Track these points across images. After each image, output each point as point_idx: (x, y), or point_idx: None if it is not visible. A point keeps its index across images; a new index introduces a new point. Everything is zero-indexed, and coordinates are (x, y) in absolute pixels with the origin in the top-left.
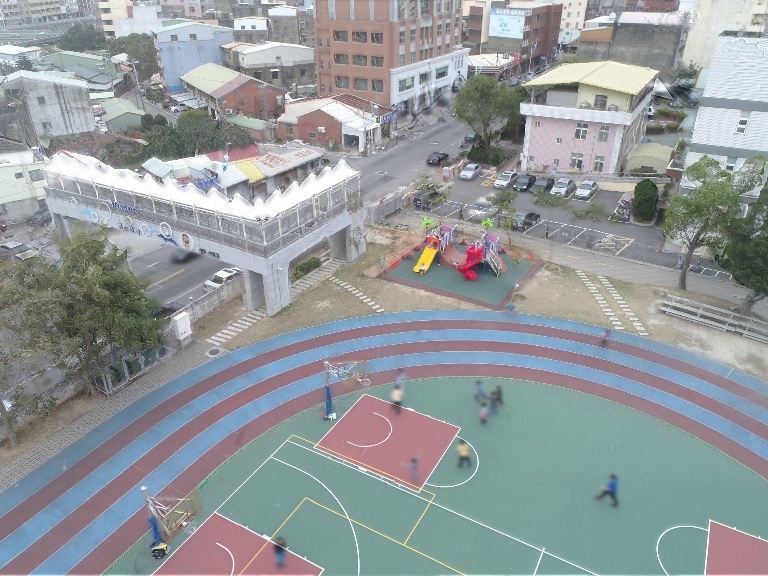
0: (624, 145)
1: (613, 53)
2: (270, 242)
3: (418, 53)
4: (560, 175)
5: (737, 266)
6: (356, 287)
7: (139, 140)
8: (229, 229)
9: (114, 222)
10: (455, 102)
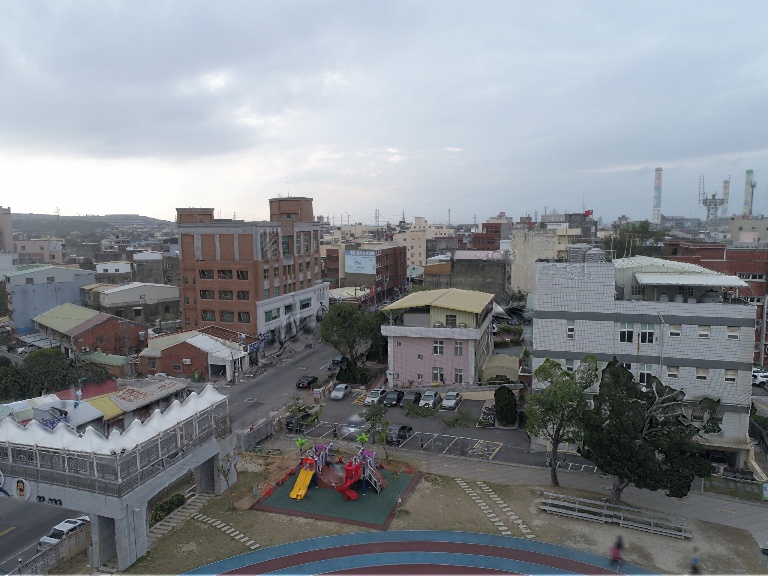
0: (478, 357)
1: (454, 283)
2: (126, 479)
3: (282, 287)
4: (425, 389)
5: (598, 455)
6: (226, 523)
7: None
8: (77, 469)
9: None
10: None
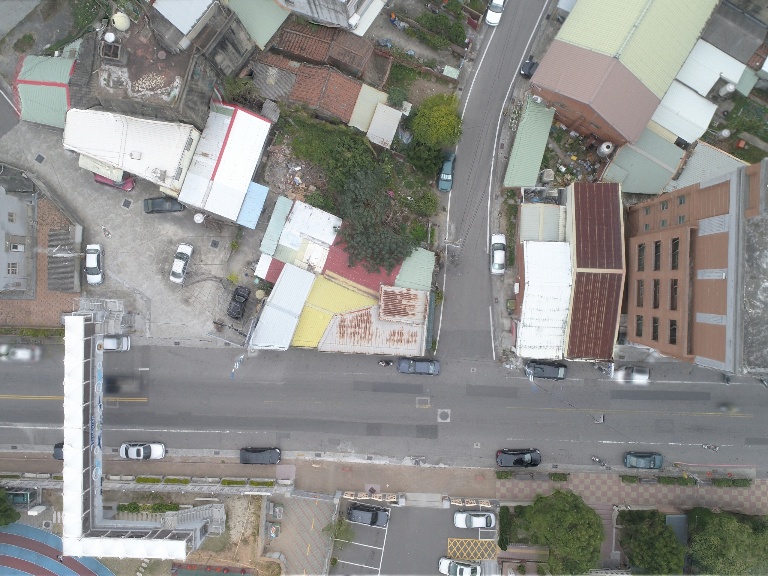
0: None
1: None
2: None
3: None
4: None
5: None
6: None
7: (368, 91)
8: None
9: None
10: (554, 495)
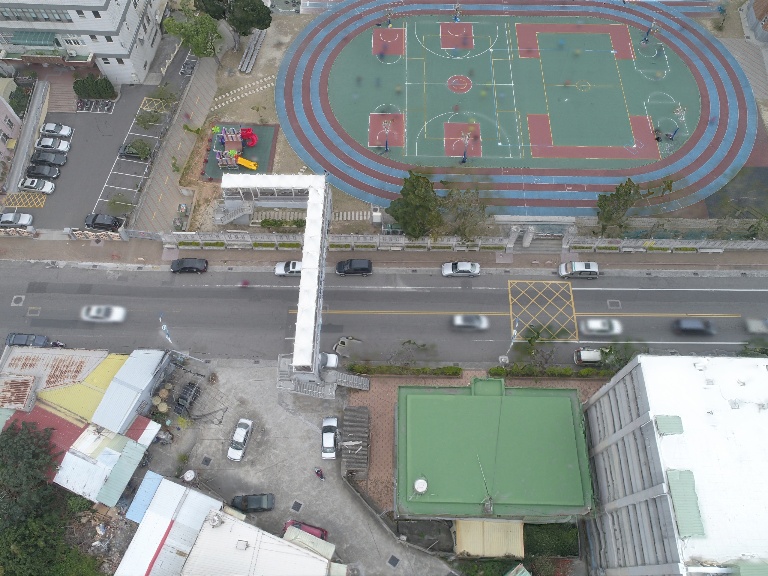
0: None
1: None
2: None
3: None
4: None
5: (261, 26)
6: None
7: None
8: None
9: None
10: None
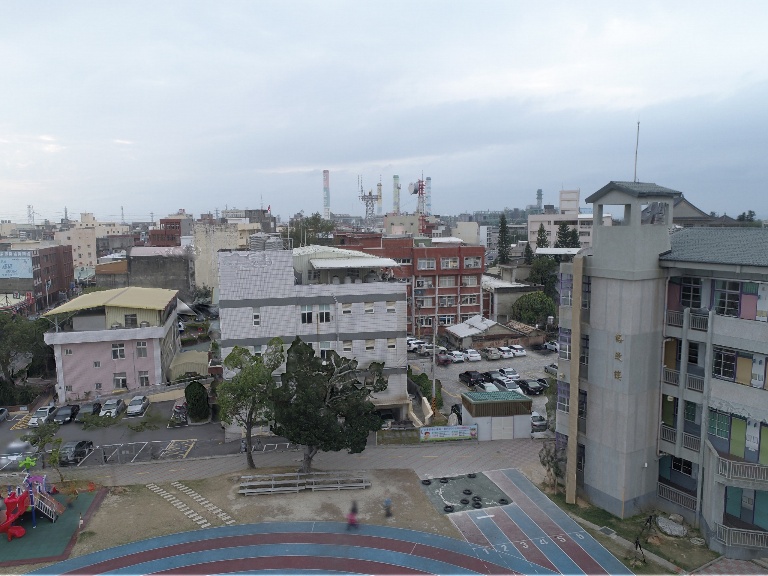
0: (164, 357)
1: (133, 282)
2: None
3: None
4: (106, 398)
5: (288, 429)
6: None
7: None
8: None
9: None
10: None
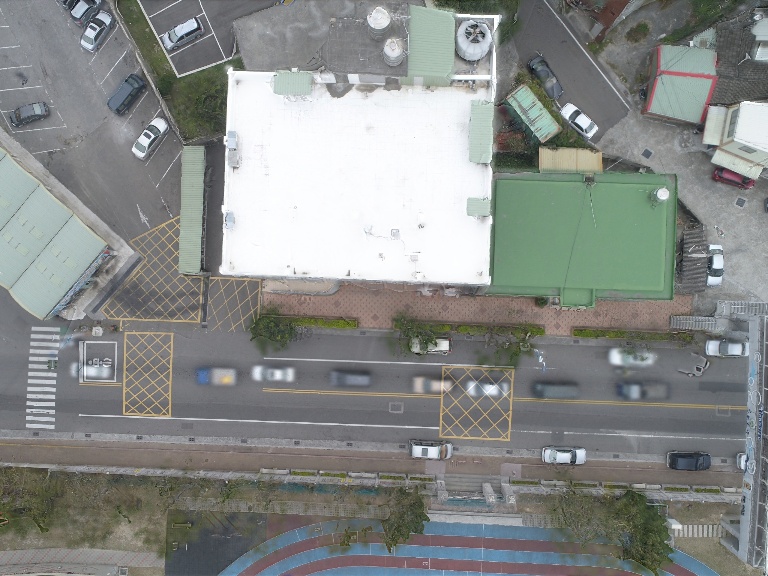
0: None
1: None
2: (760, 567)
3: None
4: None
5: None
6: None
7: None
8: None
9: (750, 405)
10: None
